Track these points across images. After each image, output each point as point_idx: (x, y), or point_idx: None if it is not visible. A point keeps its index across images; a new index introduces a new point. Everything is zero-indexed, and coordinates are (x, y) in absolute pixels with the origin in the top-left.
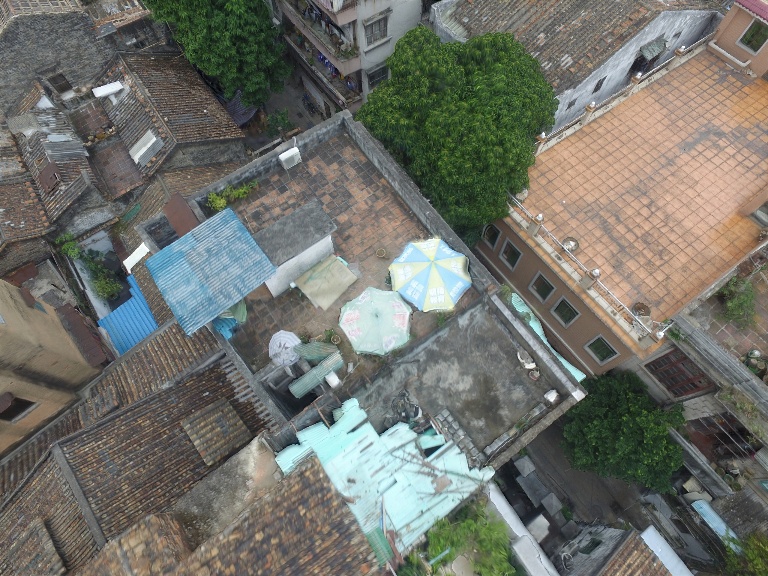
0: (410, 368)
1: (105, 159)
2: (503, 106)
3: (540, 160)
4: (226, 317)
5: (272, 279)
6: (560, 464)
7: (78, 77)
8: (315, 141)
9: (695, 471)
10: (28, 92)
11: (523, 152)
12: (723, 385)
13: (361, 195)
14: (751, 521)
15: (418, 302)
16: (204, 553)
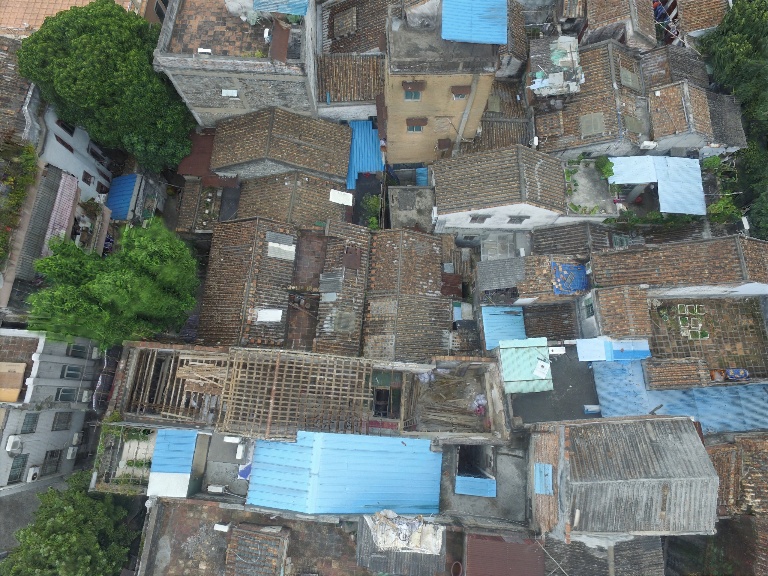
0: None
1: (314, 280)
2: None
3: None
4: None
5: None
6: None
7: None
8: None
9: None
10: None
11: None
12: None
13: (194, 23)
14: None
15: None
16: None
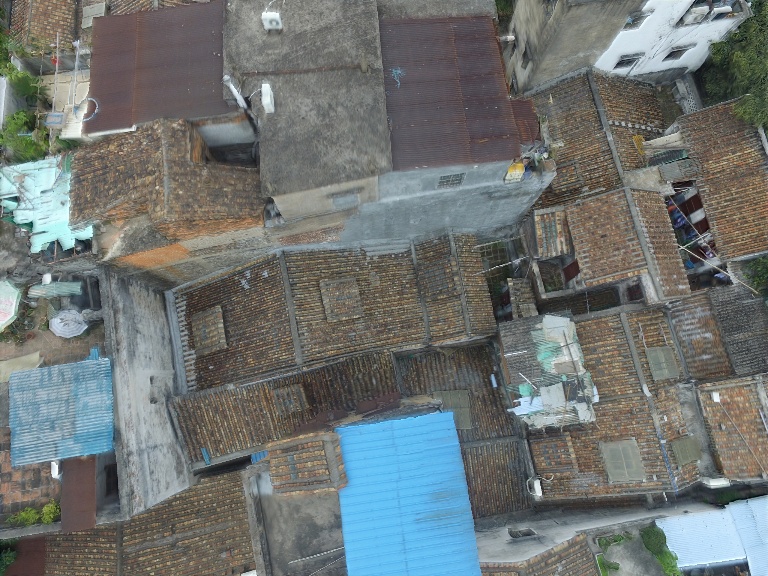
0: None
1: None
2: None
3: None
4: None
5: None
6: None
7: None
8: None
9: None
10: None
11: None
12: None
13: None
14: None
15: None
16: (132, 193)
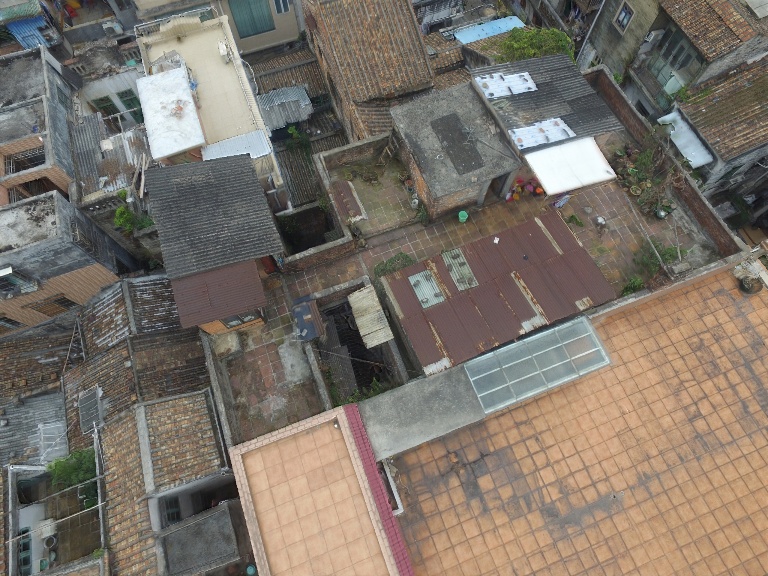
0: None
1: None
2: None
3: None
4: None
5: None
6: None
7: None
8: None
9: None
10: None
11: None
12: None
13: None
14: None
15: None
16: None
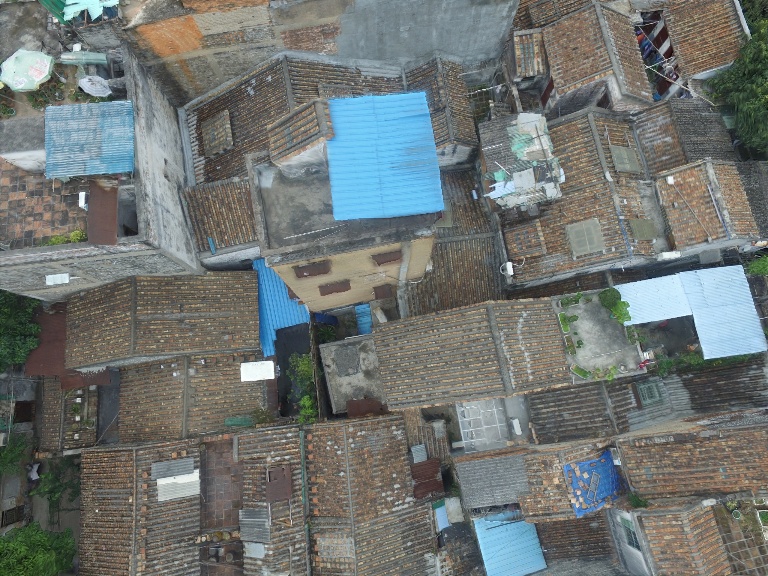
0: None
1: (235, 511)
2: None
3: None
4: None
5: None
6: None
7: None
8: None
9: None
10: None
11: None
12: None
13: None
14: None
15: None
16: None
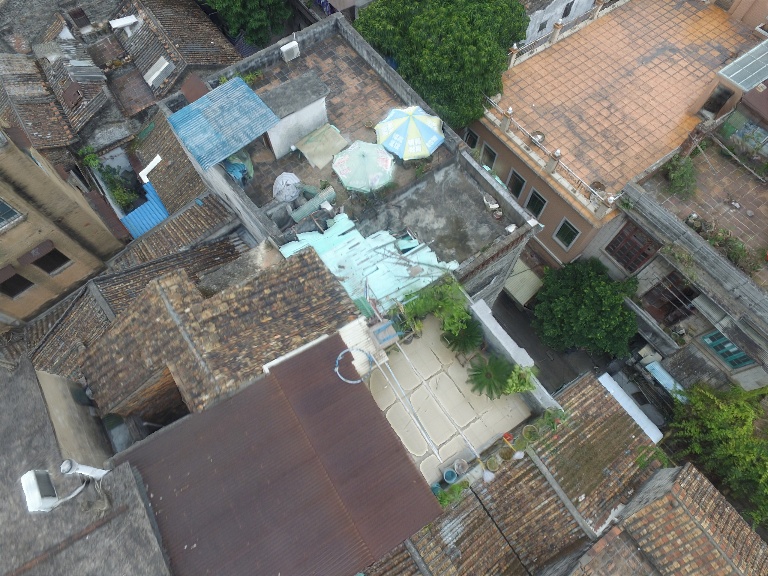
0: (393, 212)
1: (121, 85)
2: (477, 10)
3: (513, 72)
4: (237, 162)
5: (275, 136)
6: (535, 356)
7: (96, 12)
8: (312, 39)
9: (648, 336)
10: (51, 24)
11: (495, 53)
12: (665, 242)
13: (352, 82)
14: (695, 374)
15: (399, 152)
16: (224, 294)
